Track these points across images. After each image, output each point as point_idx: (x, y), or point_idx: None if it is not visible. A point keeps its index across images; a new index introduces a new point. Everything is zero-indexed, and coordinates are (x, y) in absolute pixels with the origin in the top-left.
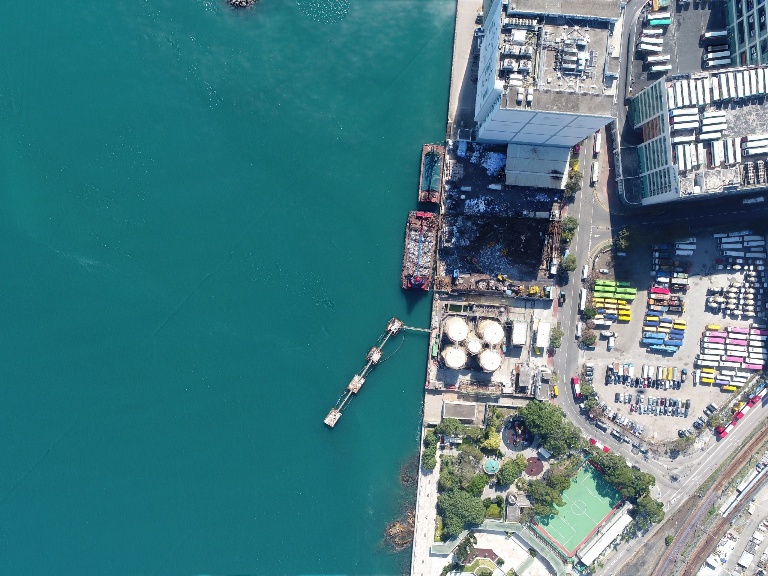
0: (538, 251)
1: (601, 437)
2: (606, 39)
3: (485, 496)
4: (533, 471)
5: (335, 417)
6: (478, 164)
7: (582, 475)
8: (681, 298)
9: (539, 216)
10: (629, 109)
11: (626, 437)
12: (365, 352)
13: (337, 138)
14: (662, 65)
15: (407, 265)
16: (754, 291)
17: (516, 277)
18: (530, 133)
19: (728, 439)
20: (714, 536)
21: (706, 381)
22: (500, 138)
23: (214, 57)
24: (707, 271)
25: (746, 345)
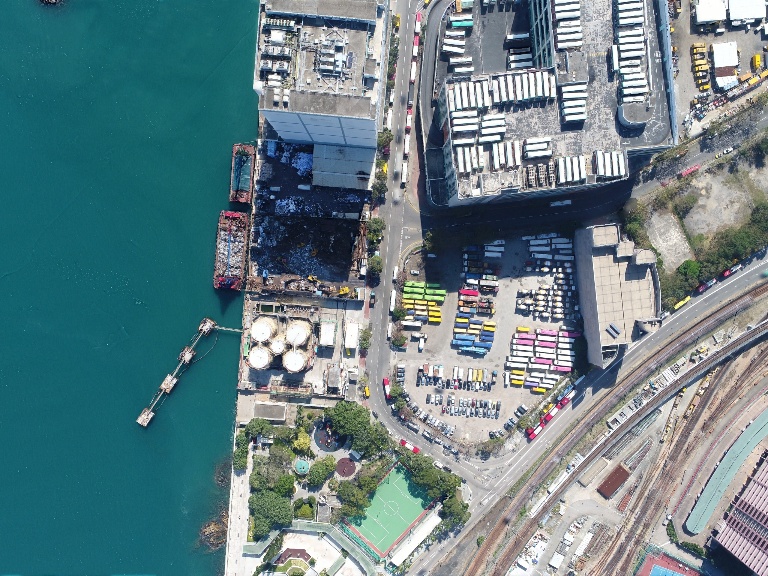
0: (347, 252)
1: (413, 438)
2: (365, 41)
3: (298, 496)
4: (345, 472)
5: (148, 417)
6: (289, 164)
7: (394, 476)
8: (490, 300)
9: (348, 217)
10: (436, 111)
11: (437, 438)
12: (178, 352)
13: (149, 137)
14: (466, 67)
15: (218, 265)
16: (562, 293)
17: (327, 278)
18: (320, 134)
19: (539, 441)
20: (523, 537)
21: (516, 383)
22: (303, 138)
23: (11, 54)
24: (517, 273)
25: (556, 347)
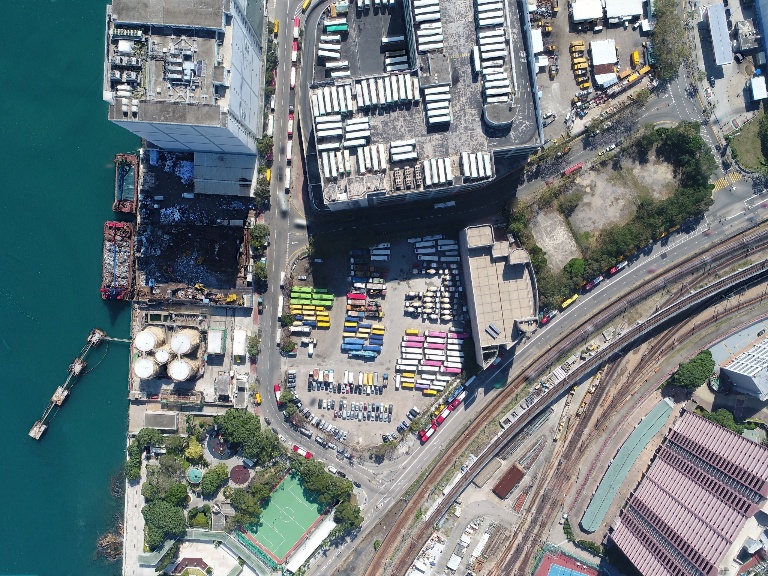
0: (232, 259)
1: (306, 444)
2: (214, 48)
3: (193, 505)
4: (240, 479)
5: (40, 430)
6: (172, 173)
7: (289, 482)
8: (378, 303)
9: (233, 224)
10: None
11: (330, 443)
12: (69, 364)
13: (32, 149)
14: (343, 71)
15: (104, 275)
16: (449, 295)
17: (215, 285)
18: (191, 142)
19: (432, 443)
20: (418, 540)
21: (406, 385)
22: (181, 147)
23: None
24: (405, 276)
25: (446, 349)
